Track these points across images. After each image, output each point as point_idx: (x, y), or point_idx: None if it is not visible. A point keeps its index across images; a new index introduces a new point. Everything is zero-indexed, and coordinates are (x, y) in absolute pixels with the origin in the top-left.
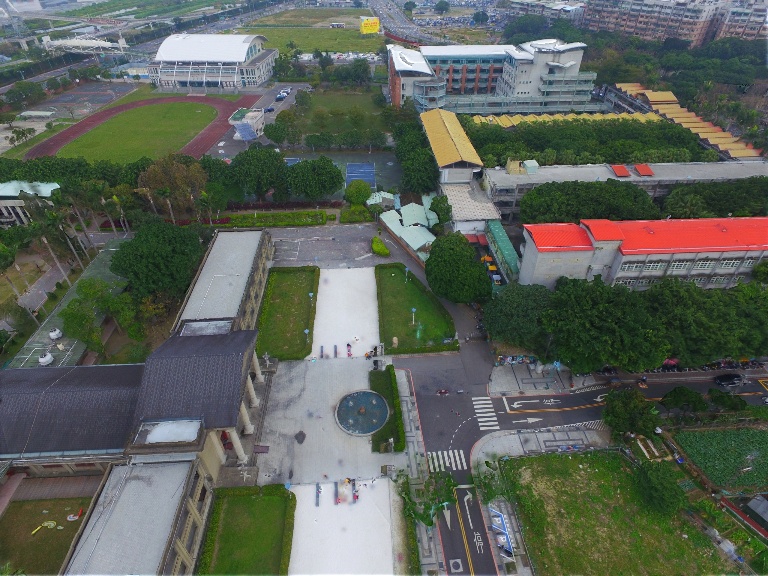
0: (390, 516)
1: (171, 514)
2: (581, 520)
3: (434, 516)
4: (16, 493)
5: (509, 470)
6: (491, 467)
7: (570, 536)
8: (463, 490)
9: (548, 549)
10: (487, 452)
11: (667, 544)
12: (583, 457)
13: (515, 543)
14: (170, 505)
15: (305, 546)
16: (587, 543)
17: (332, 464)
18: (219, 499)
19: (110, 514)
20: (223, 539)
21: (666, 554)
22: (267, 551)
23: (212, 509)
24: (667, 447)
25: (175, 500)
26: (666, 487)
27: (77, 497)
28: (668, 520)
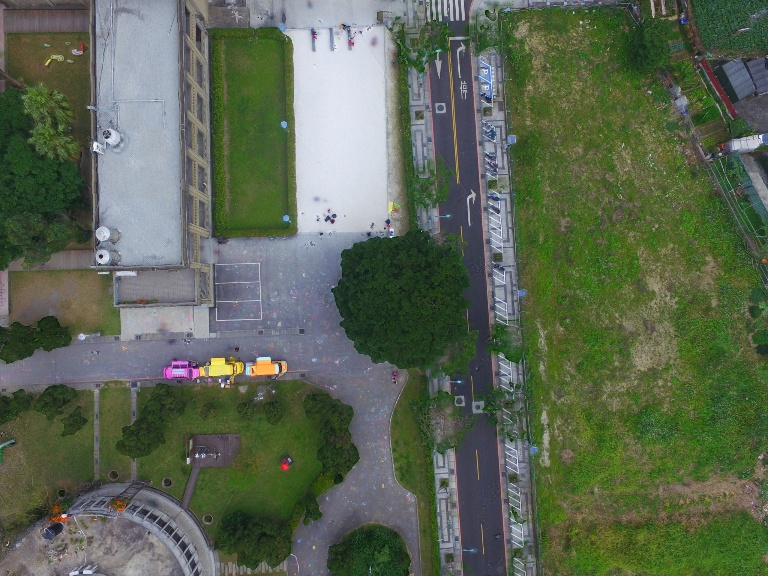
0: (384, 64)
1: (174, 49)
2: (562, 74)
3: (426, 65)
4: (6, 25)
5: (507, 23)
6: (490, 17)
7: (547, 88)
8: (457, 42)
9: (524, 98)
10: (489, 2)
11: (630, 98)
12: (587, 12)
13: (496, 92)
14: (170, 40)
15: (306, 87)
16: (560, 94)
17: (326, 8)
18: (216, 40)
19: (114, 46)
20: (229, 78)
21: (625, 106)
22: (272, 90)
23: (212, 49)
24: (678, 5)
25: (173, 35)
26: (655, 45)
27: (71, 32)
28: (642, 78)
